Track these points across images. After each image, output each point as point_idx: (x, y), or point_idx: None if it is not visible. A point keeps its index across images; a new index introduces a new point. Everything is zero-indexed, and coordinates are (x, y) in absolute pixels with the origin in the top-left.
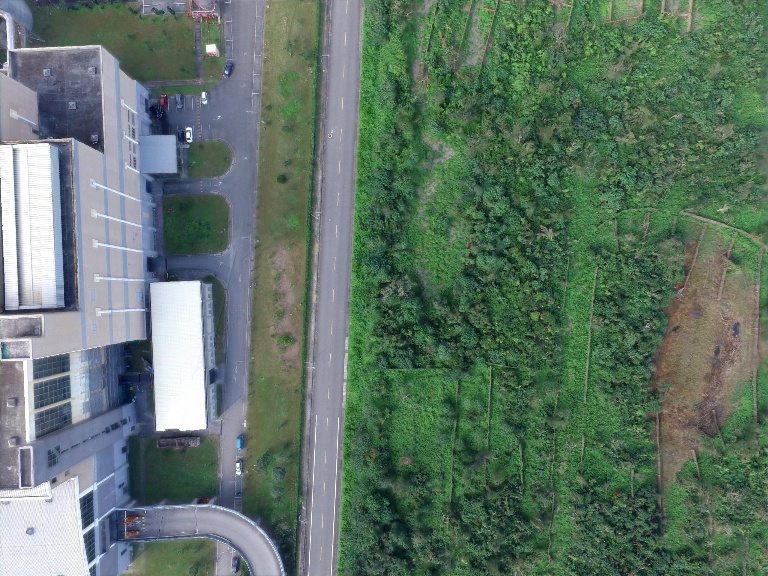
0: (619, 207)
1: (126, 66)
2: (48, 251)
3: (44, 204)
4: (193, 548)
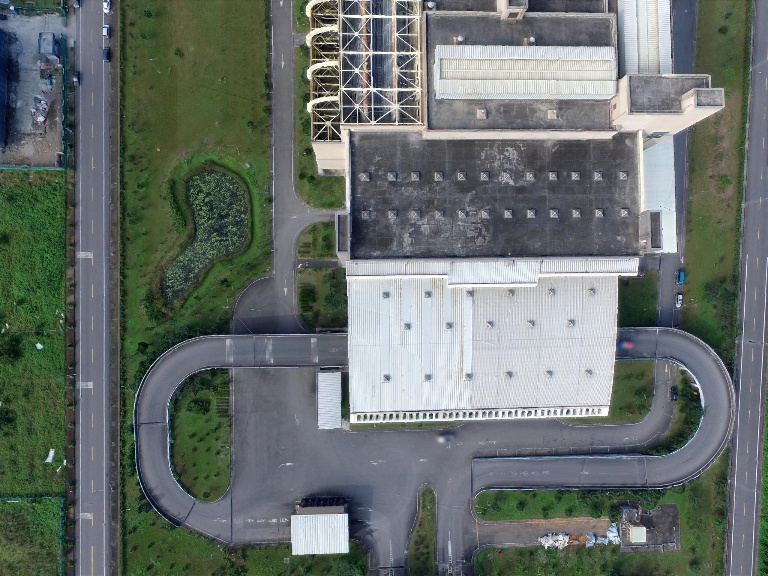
0: None
1: None
2: (666, 33)
3: None
4: (635, 377)
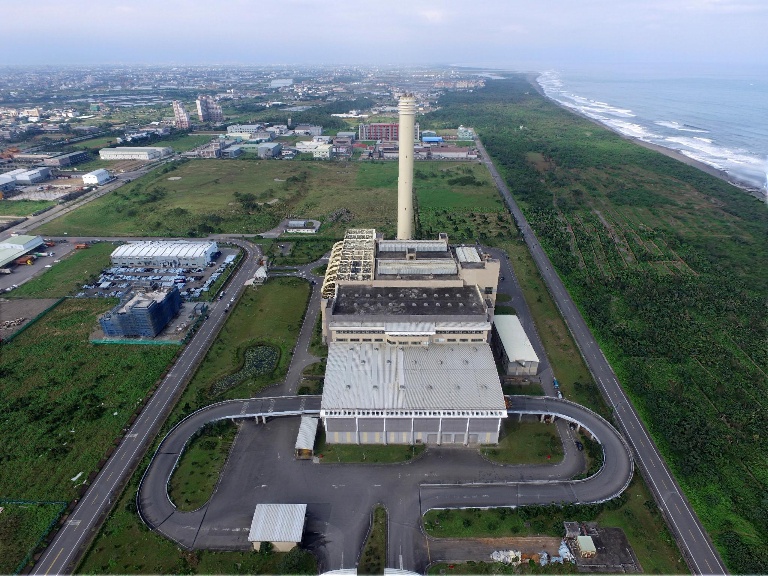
0: (716, 314)
1: None
2: None
3: (476, 256)
4: (543, 434)
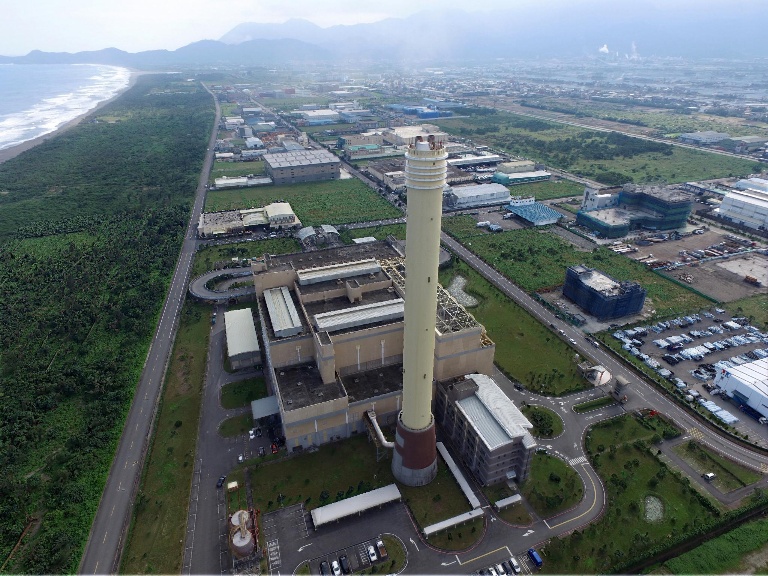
0: None
1: (309, 464)
2: None
3: None
4: None
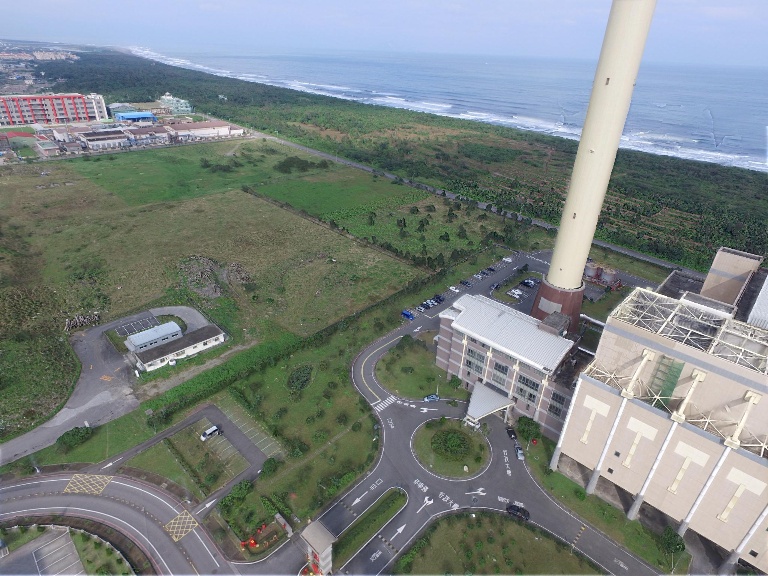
0: None
1: None
2: None
3: None
4: None
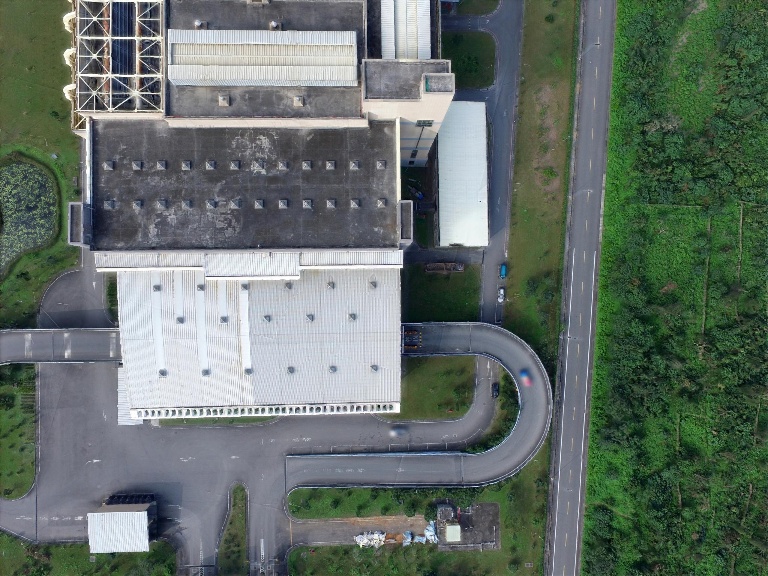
0: None
1: None
2: (425, 18)
3: None
4: (455, 373)
